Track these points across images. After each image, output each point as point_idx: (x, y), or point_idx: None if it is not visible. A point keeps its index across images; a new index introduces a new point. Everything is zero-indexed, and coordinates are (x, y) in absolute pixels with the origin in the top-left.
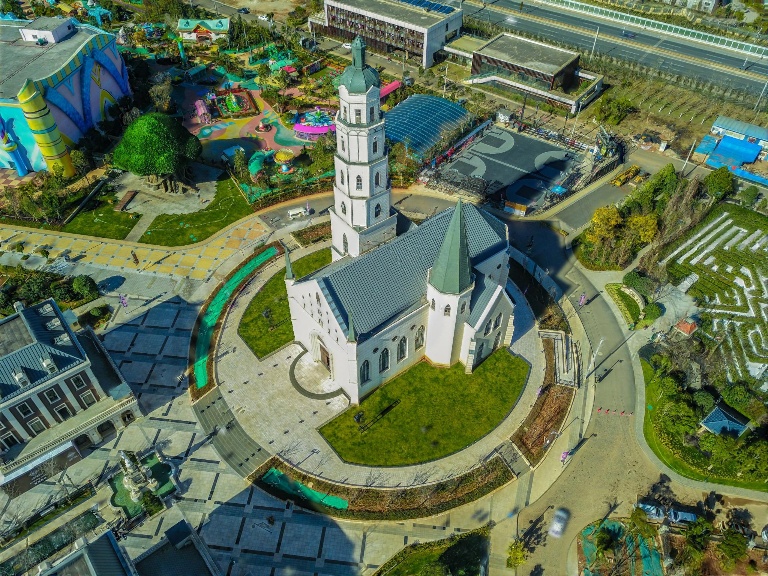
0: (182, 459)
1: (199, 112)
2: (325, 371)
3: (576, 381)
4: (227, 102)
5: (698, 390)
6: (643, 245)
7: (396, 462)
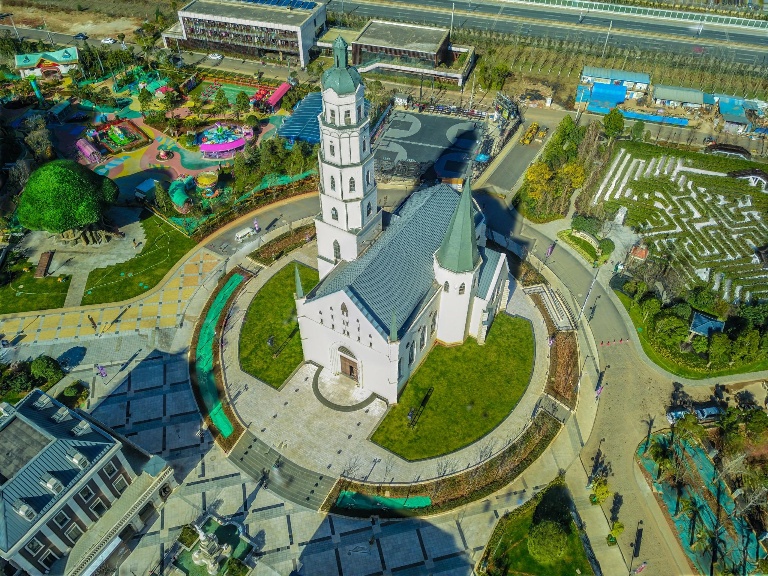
0: (243, 514)
1: (86, 152)
2: (350, 381)
3: (573, 324)
4: (111, 136)
5: (669, 304)
6: (572, 191)
7: (457, 445)
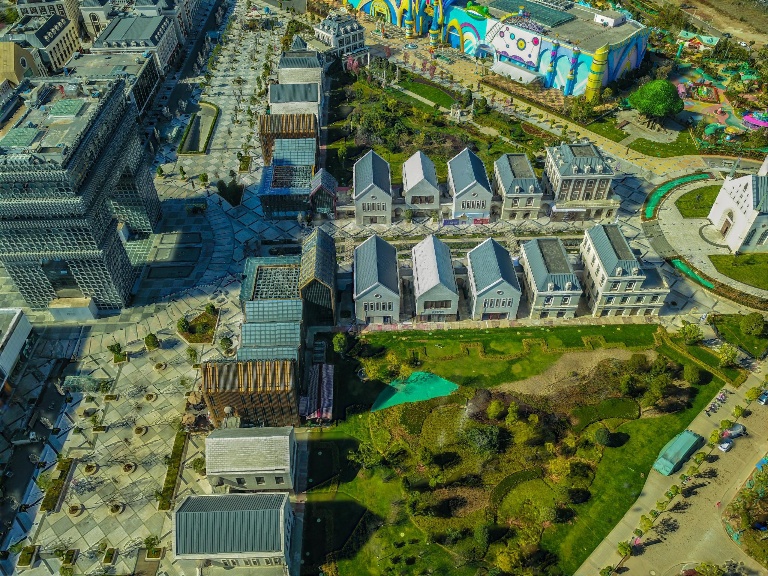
0: (631, 240)
1: (680, 91)
2: (721, 235)
3: None
4: (699, 91)
5: None
6: None
7: (748, 283)
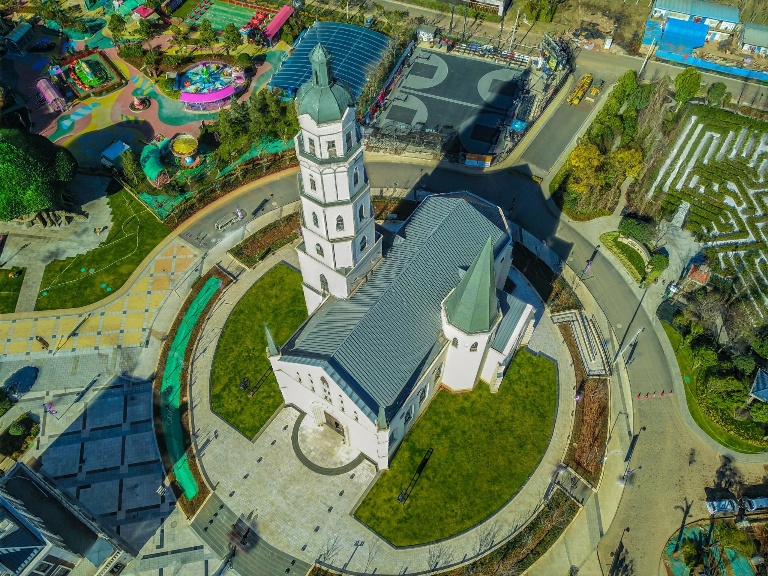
0: None
1: (47, 98)
2: (335, 435)
3: (607, 368)
4: (78, 74)
5: None
6: (624, 177)
7: (453, 530)
